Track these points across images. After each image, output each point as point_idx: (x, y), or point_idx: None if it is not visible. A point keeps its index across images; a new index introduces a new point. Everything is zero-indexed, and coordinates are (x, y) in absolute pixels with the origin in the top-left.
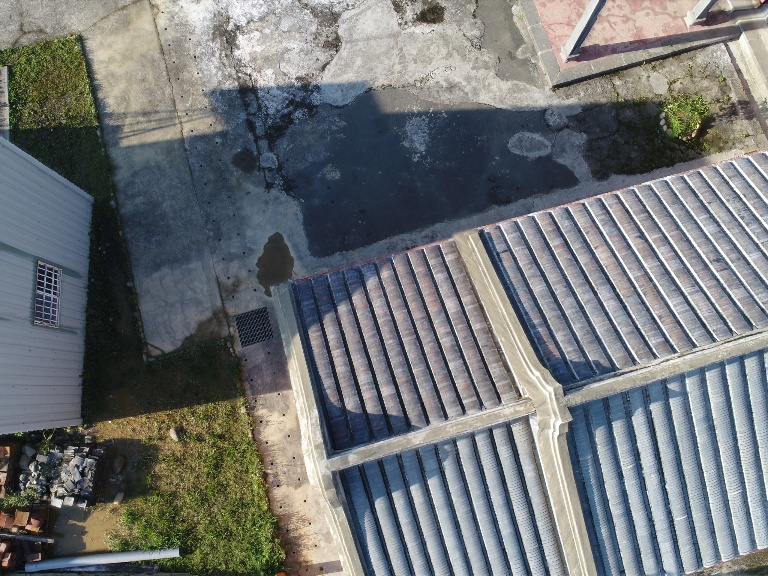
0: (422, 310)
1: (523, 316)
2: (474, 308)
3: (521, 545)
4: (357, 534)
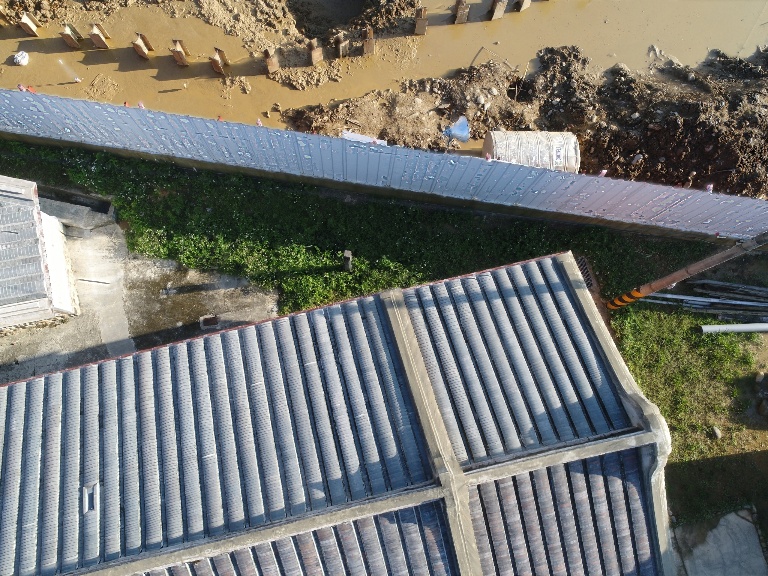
0: (539, 573)
1: (450, 568)
2: (488, 574)
3: (451, 345)
4: (604, 365)
